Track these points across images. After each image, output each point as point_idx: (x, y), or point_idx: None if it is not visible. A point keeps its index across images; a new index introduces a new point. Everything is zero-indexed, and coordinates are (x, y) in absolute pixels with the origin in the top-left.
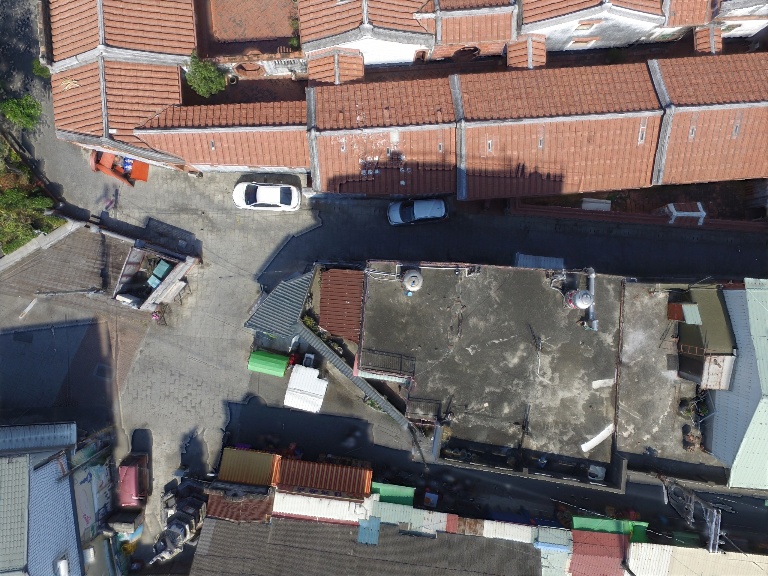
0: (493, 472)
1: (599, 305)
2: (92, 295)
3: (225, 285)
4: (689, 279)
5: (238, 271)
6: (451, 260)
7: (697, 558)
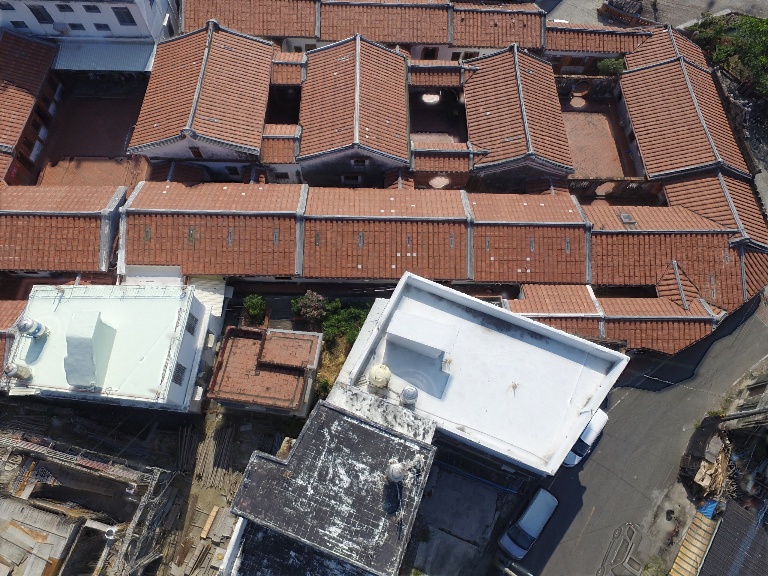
0: None
1: None
2: (661, 2)
3: (582, 0)
4: None
5: (575, 5)
6: None
7: None
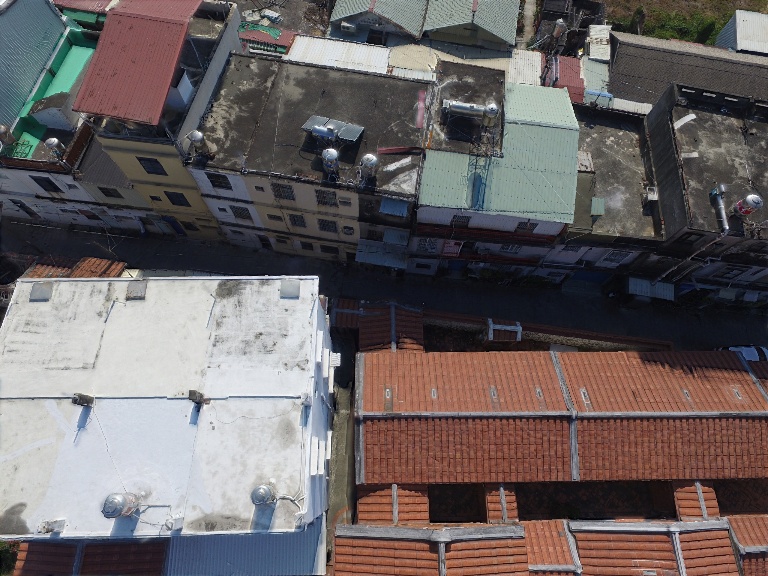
0: None
1: (708, 209)
2: None
3: None
4: (576, 244)
5: None
6: (695, 315)
7: None
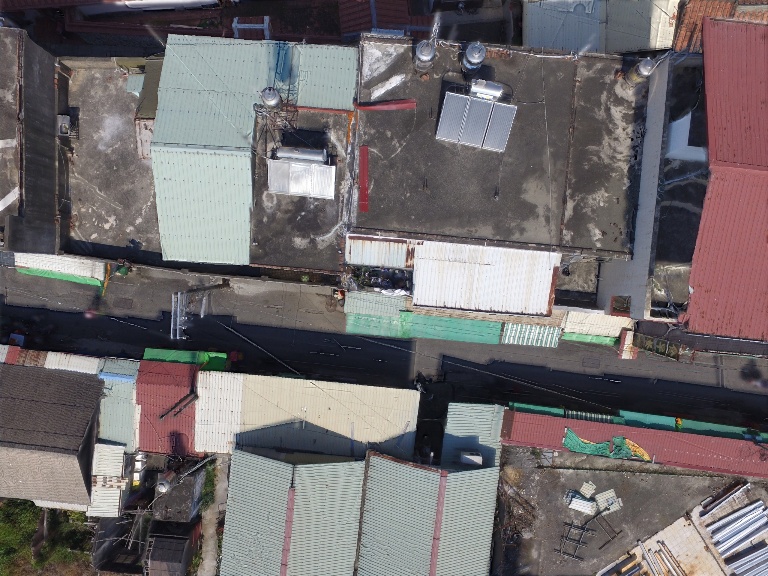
0: (91, 315)
1: None
2: None
3: None
4: None
5: None
6: None
7: (270, 386)
